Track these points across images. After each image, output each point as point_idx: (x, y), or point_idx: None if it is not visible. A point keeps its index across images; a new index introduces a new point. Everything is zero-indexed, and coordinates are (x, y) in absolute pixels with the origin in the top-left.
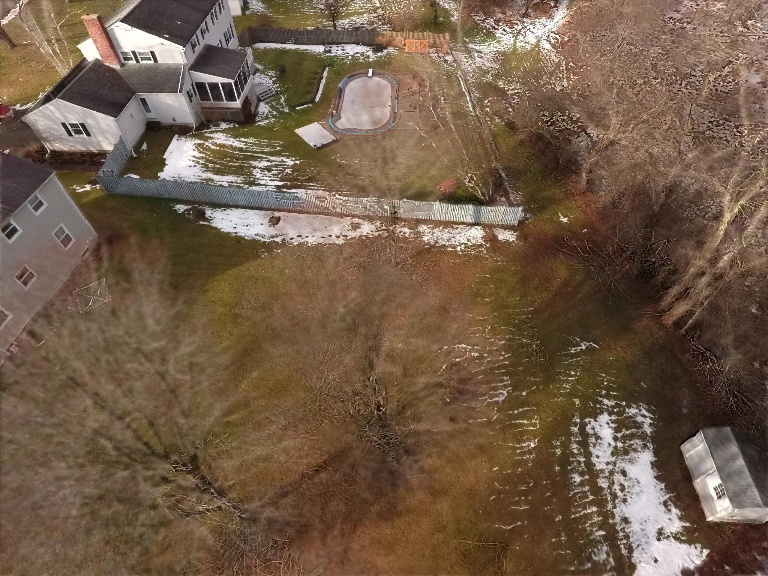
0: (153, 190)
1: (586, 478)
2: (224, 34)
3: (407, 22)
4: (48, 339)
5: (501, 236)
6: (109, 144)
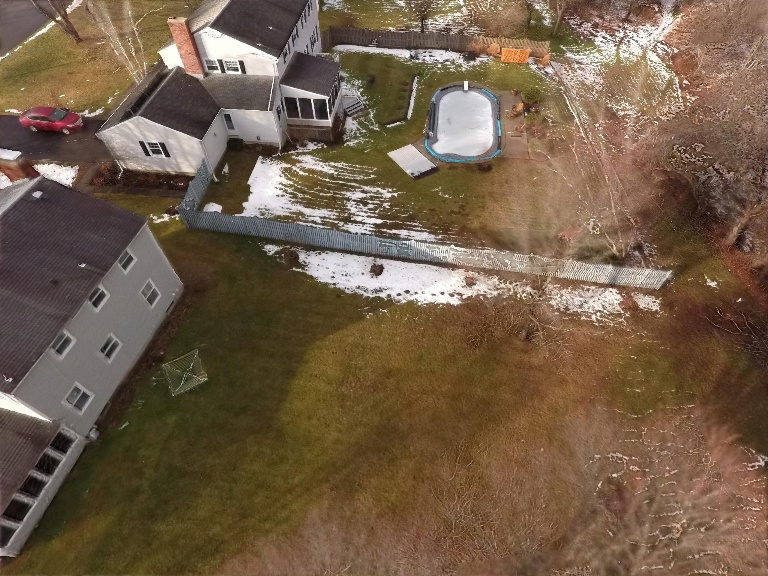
0: (241, 227)
1: None
2: (310, 38)
3: (496, 24)
4: (132, 420)
5: (642, 303)
6: (189, 166)
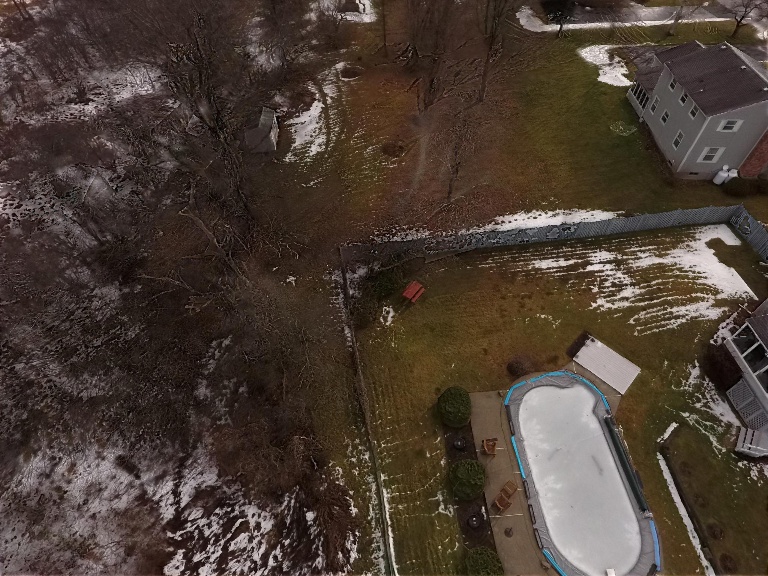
0: (687, 218)
1: (332, 130)
2: None
3: None
4: None
5: None
6: None
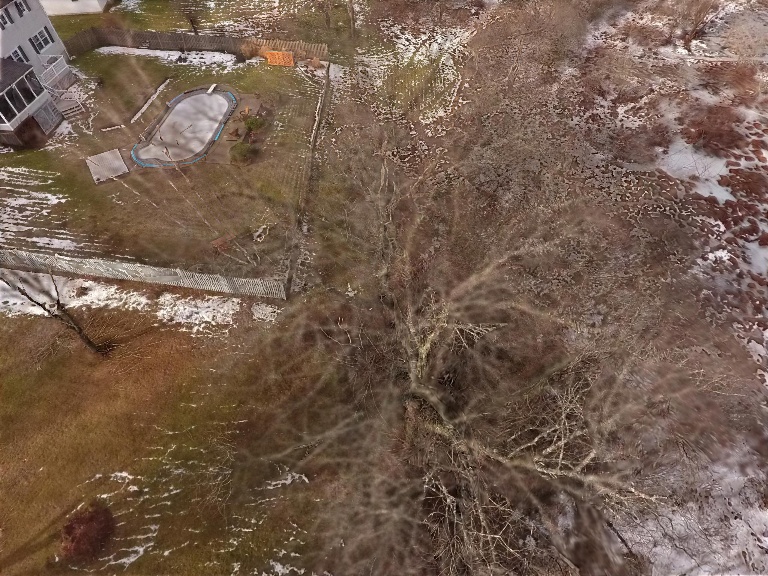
0: None
1: None
2: (30, 39)
3: (298, 26)
4: None
5: (257, 314)
6: None
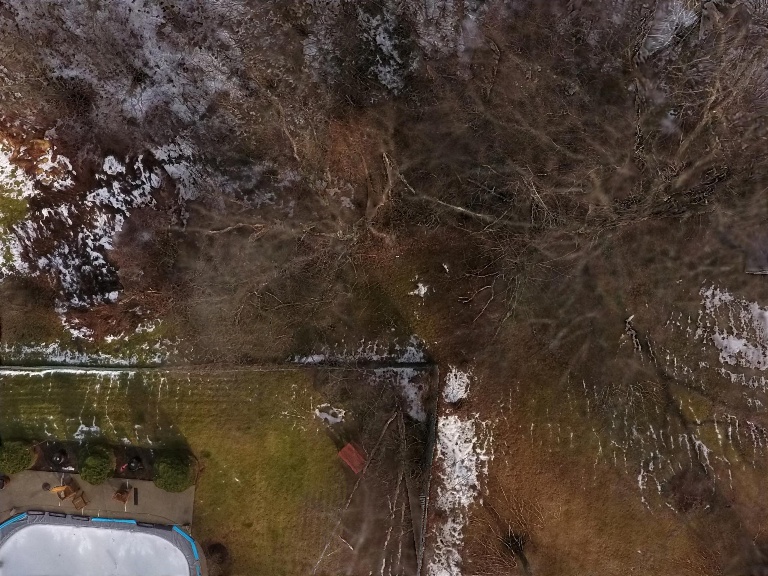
0: None
1: None
2: None
3: None
4: None
5: (460, 394)
6: None
